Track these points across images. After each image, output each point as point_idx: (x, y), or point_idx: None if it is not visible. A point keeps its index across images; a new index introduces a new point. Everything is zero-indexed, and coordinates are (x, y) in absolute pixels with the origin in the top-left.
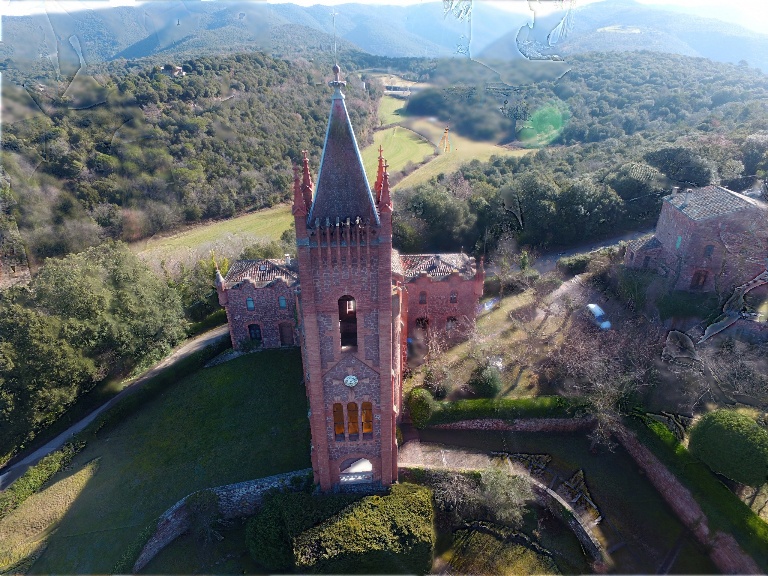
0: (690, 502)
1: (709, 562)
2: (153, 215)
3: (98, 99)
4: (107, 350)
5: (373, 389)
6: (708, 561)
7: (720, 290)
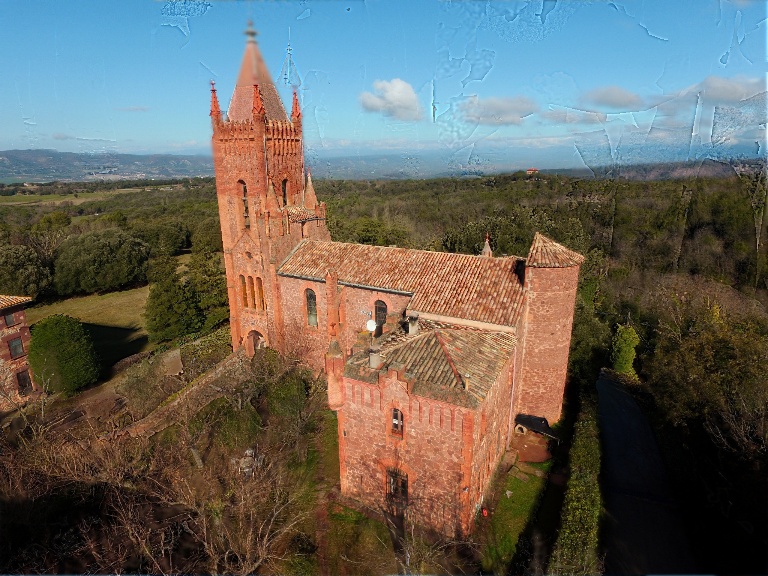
0: None
1: None
2: None
3: (766, 86)
4: None
5: None
6: None
7: None
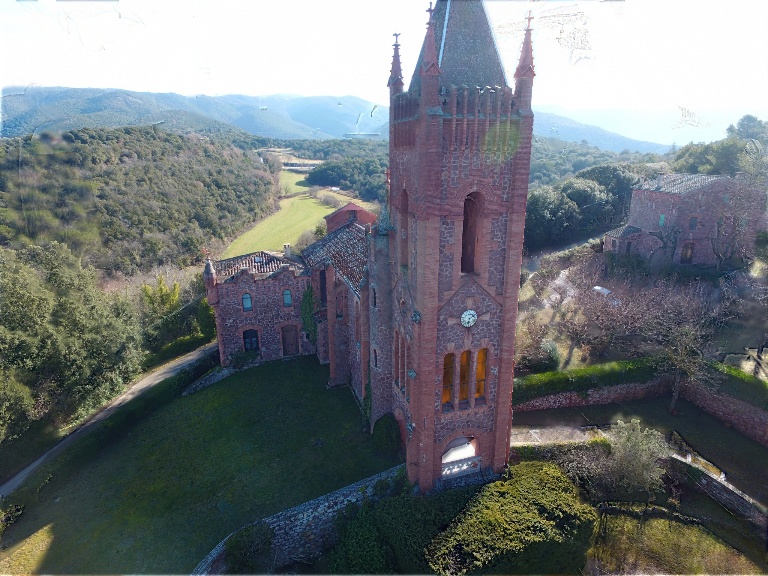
0: None
1: None
2: None
3: (14, 89)
4: (47, 376)
5: (492, 329)
6: None
7: (722, 250)
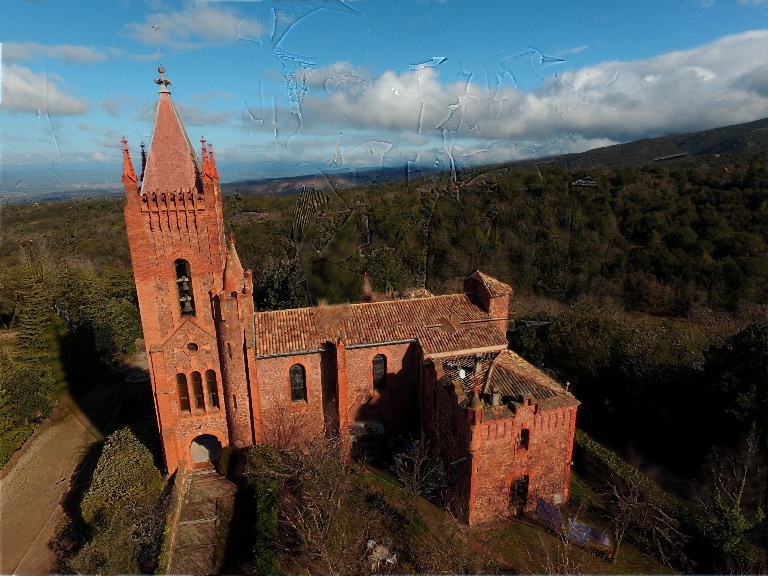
0: None
1: None
2: (538, 263)
3: (480, 148)
4: None
5: None
6: None
7: None
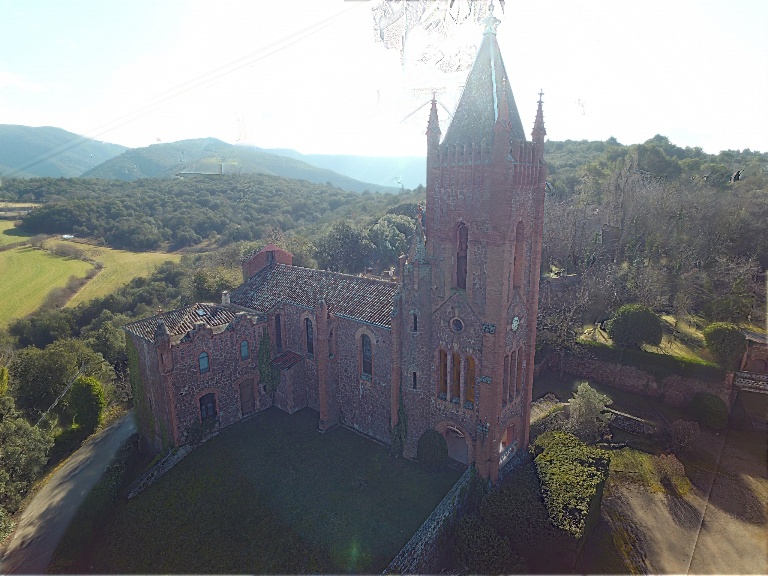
0: (637, 374)
1: (667, 404)
2: None
3: None
4: None
5: (524, 330)
6: (666, 404)
7: None
